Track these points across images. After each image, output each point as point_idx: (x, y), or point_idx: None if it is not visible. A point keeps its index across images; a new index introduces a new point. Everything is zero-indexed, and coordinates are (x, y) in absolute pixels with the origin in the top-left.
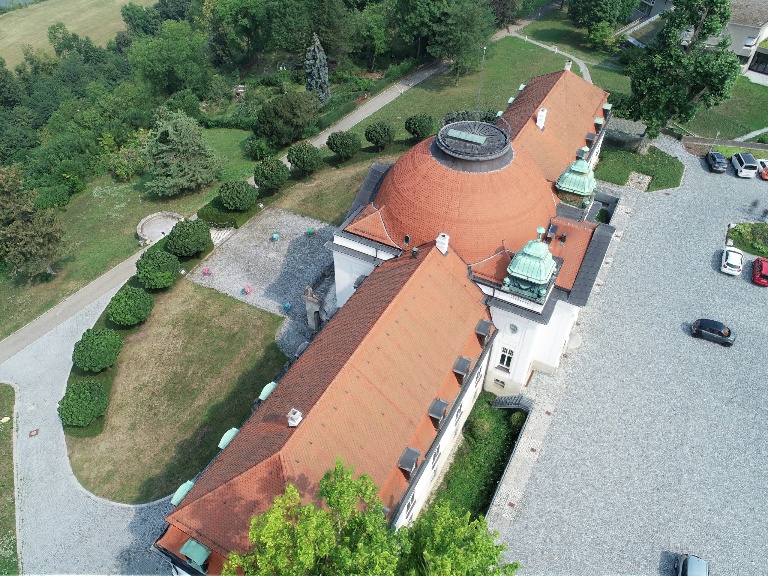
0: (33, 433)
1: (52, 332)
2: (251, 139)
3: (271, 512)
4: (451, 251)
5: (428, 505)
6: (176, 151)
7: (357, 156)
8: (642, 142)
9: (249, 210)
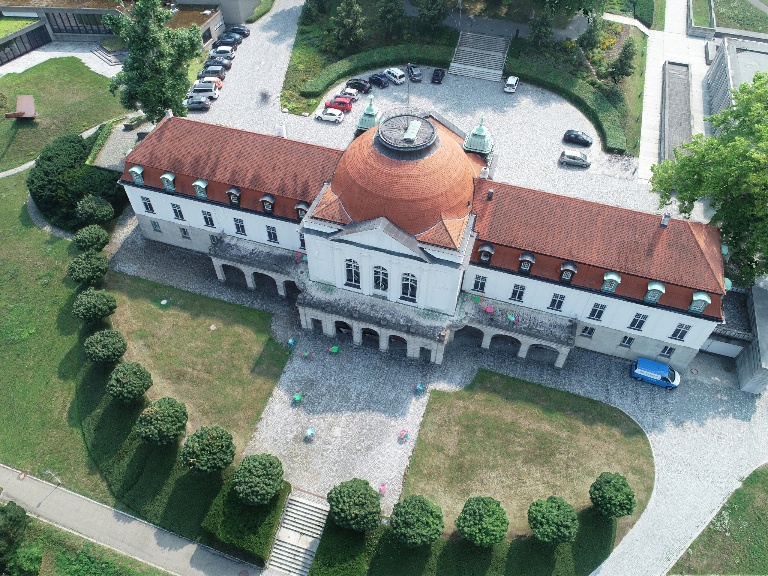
0: None
1: None
2: None
3: (753, 176)
4: None
5: None
6: None
7: None
8: None
9: None
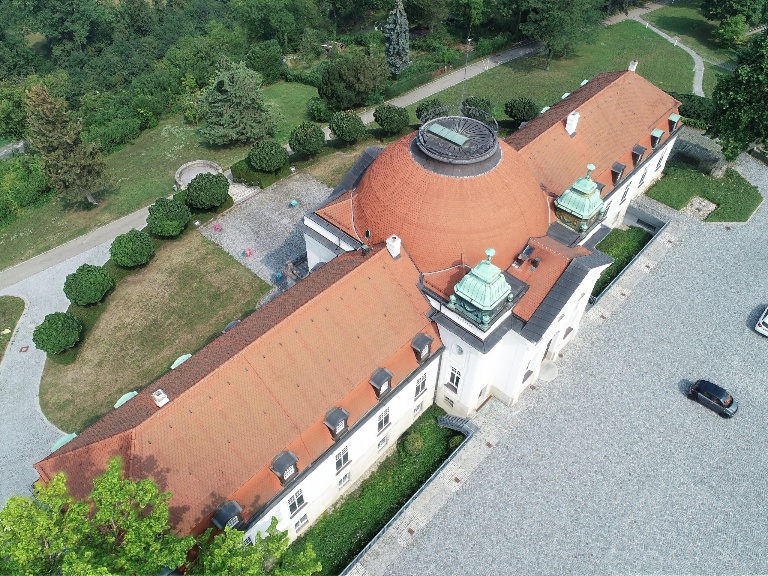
0: (23, 349)
1: (74, 258)
2: (314, 99)
3: None
4: (405, 255)
5: (333, 508)
6: (231, 102)
7: (405, 132)
8: (717, 163)
9: (280, 172)
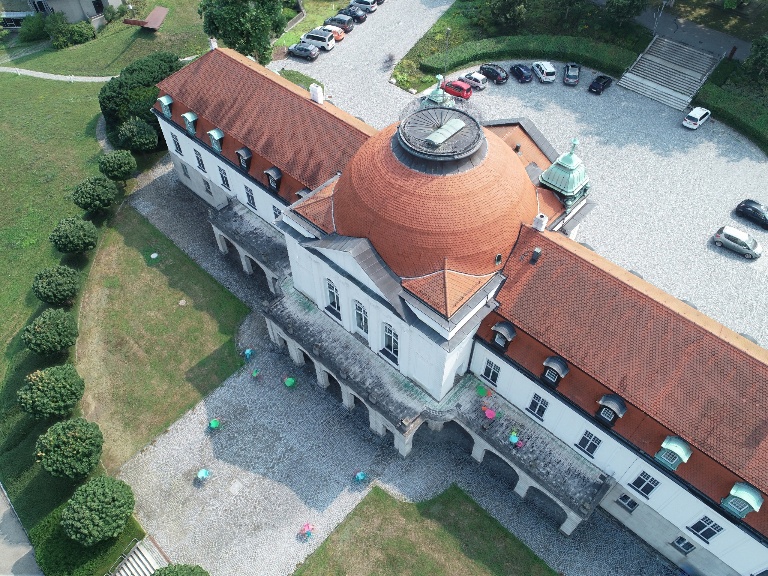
0: None
1: None
2: None
3: None
4: None
5: None
6: None
7: None
8: None
9: None
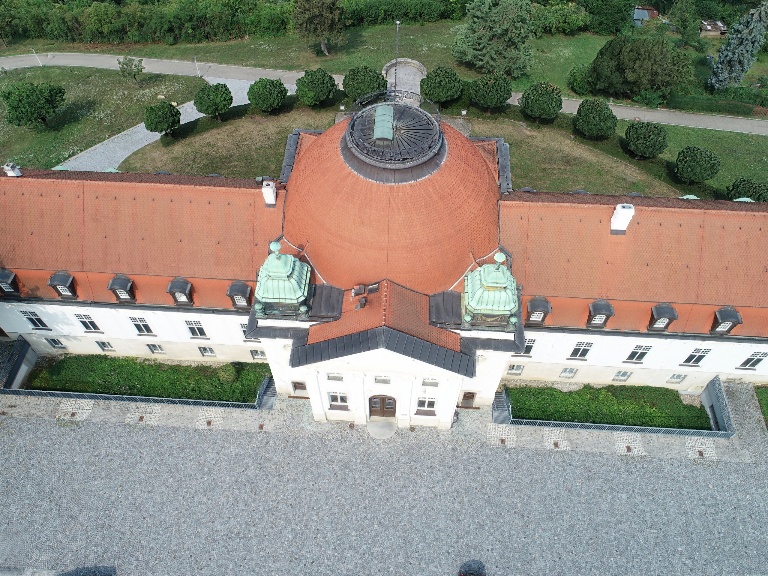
0: None
1: None
2: None
3: None
4: (280, 209)
5: (143, 361)
6: None
7: (607, 144)
8: None
9: (450, 108)
